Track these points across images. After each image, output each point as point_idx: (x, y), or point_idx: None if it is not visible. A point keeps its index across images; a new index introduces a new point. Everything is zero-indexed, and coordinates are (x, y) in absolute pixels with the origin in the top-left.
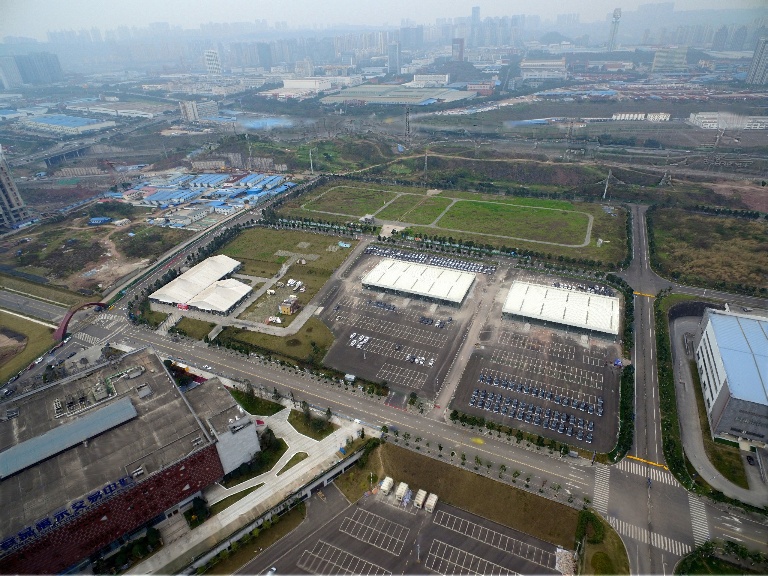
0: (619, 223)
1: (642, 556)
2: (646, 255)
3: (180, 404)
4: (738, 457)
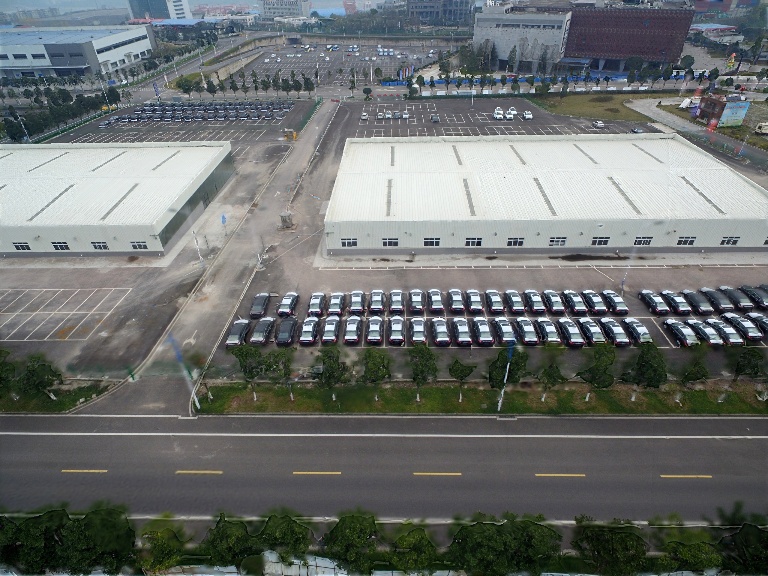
0: None
1: None
2: None
3: None
4: None
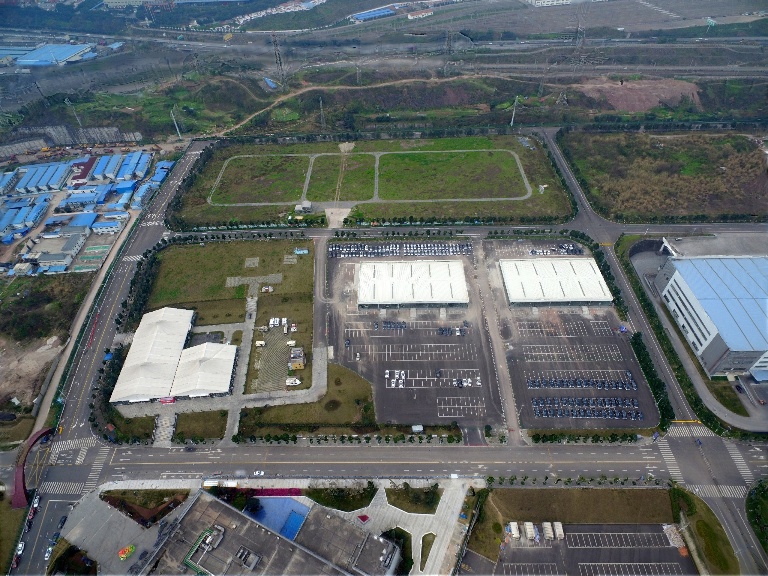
0: (541, 158)
1: (723, 510)
2: (582, 194)
3: (303, 558)
4: (731, 389)
